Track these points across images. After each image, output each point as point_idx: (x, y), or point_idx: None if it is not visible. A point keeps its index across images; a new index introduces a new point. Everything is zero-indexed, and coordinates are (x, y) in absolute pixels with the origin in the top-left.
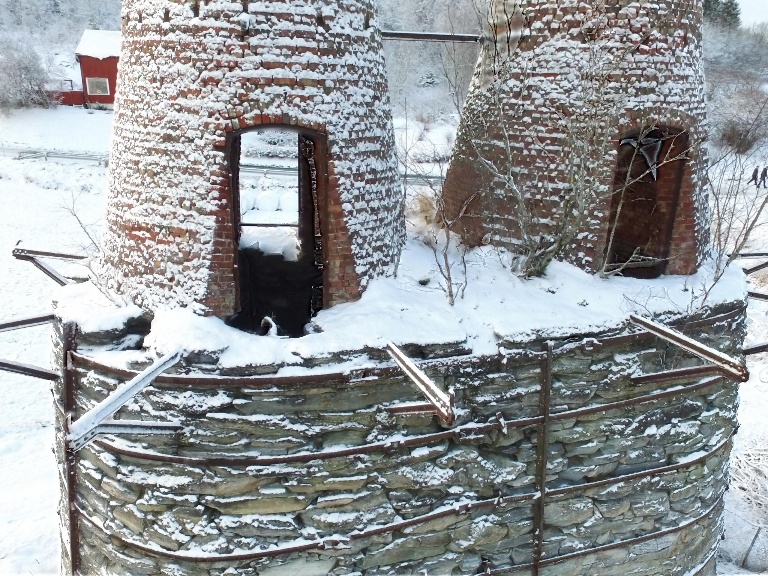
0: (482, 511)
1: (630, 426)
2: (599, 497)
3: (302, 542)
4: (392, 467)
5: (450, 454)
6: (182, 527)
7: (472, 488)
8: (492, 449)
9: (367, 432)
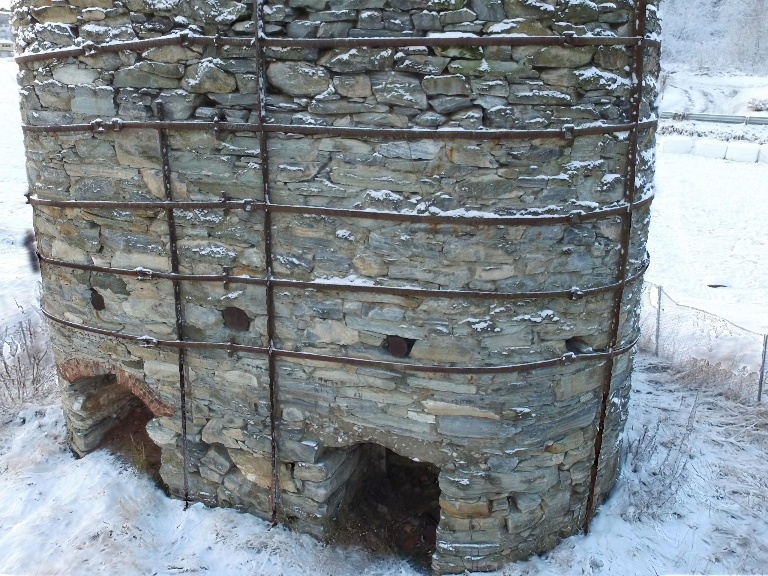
0: (211, 54)
1: None
2: (332, 66)
3: (73, 47)
4: None
5: None
6: (24, 36)
7: (196, 22)
8: None
9: None
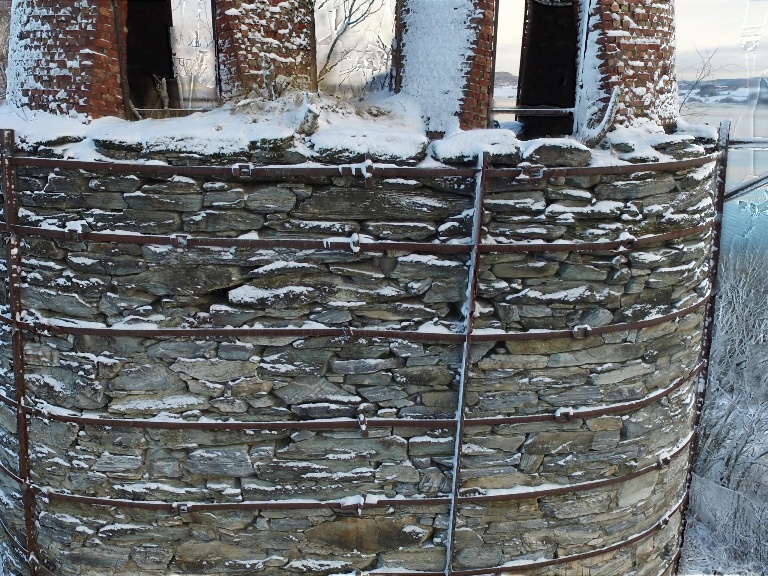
0: None
1: None
2: None
3: None
4: None
5: None
6: None
7: None
8: None
9: None
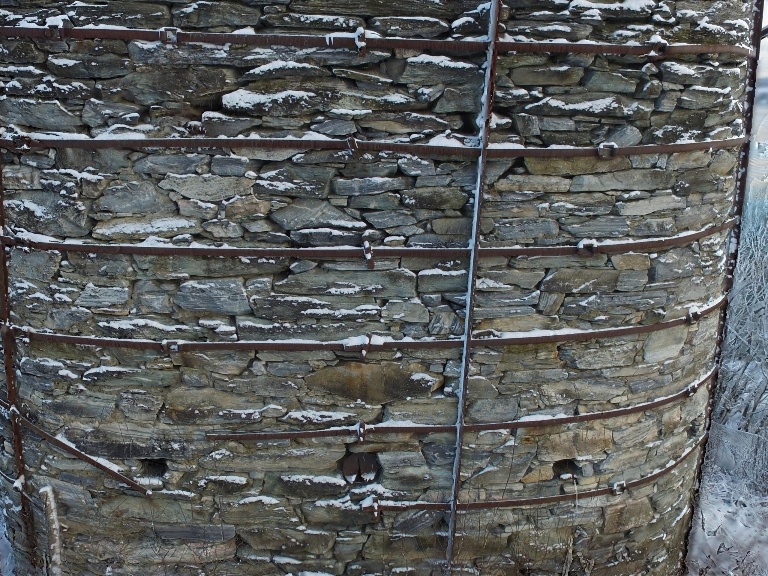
0: None
1: None
2: None
3: None
4: None
5: None
6: None
7: None
8: None
9: None
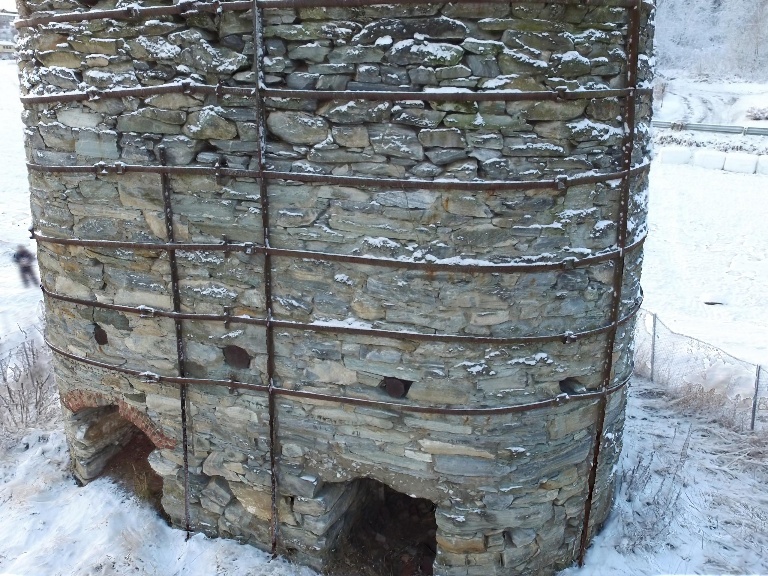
0: (212, 102)
1: (359, 33)
2: (330, 117)
3: (77, 92)
4: (136, 37)
5: (179, 32)
6: None
7: (197, 71)
8: (225, 42)
9: (117, 0)
